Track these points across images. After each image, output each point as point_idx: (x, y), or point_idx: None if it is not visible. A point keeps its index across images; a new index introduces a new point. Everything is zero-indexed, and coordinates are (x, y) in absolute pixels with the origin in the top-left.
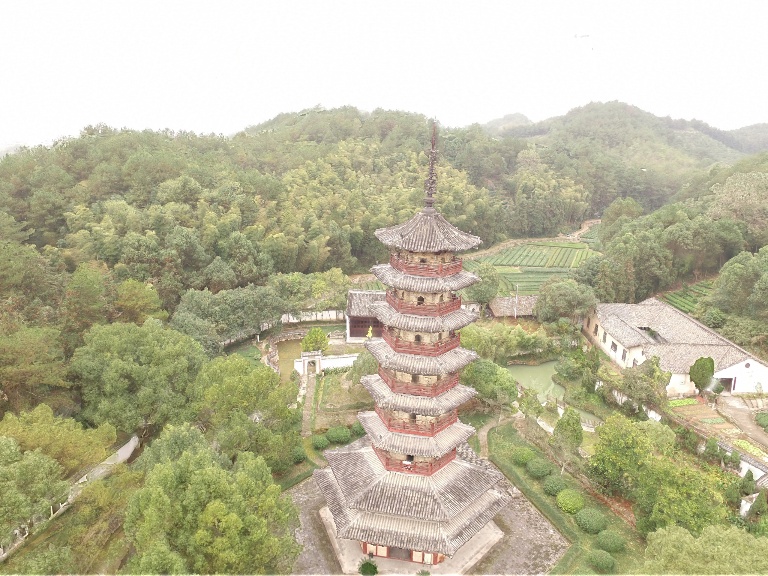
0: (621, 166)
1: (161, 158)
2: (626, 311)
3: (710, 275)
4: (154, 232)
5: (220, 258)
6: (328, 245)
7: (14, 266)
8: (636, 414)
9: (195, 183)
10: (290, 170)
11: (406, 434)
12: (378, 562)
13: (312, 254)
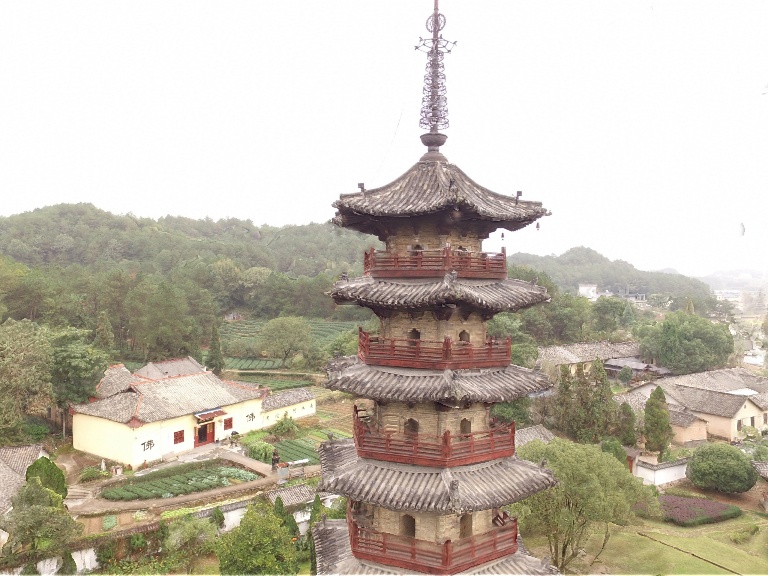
0: None
1: None
2: None
3: None
4: None
5: None
6: None
7: None
8: (62, 573)
9: None
10: None
11: None
12: None
13: None
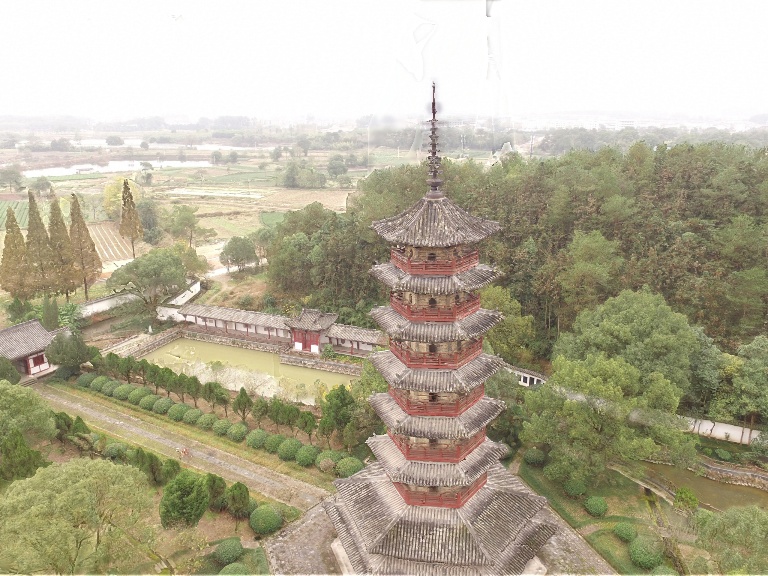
0: None
1: None
2: None
3: None
4: None
5: None
6: None
7: (733, 240)
8: None
9: None
10: None
11: None
12: None
13: None
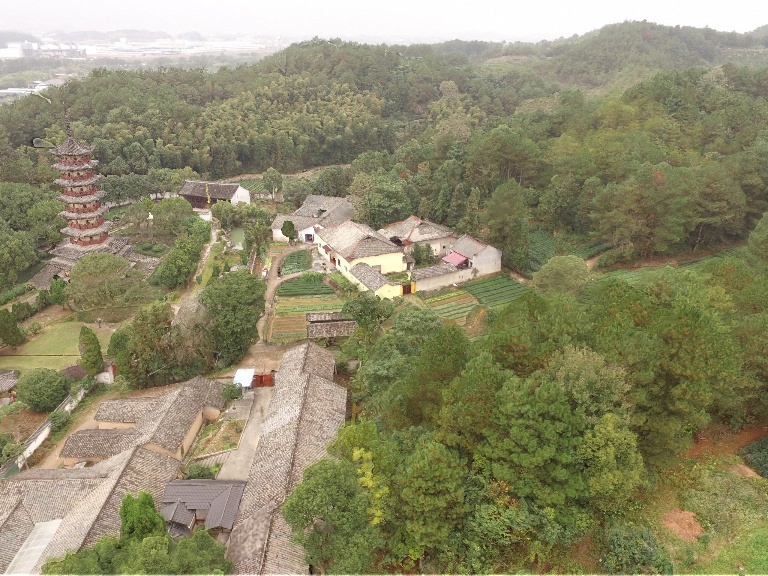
0: None
1: (119, 94)
2: (322, 200)
3: None
4: (84, 141)
5: None
6: (218, 153)
7: None
8: None
9: (129, 111)
10: (228, 99)
11: (74, 228)
12: (67, 278)
13: (194, 158)
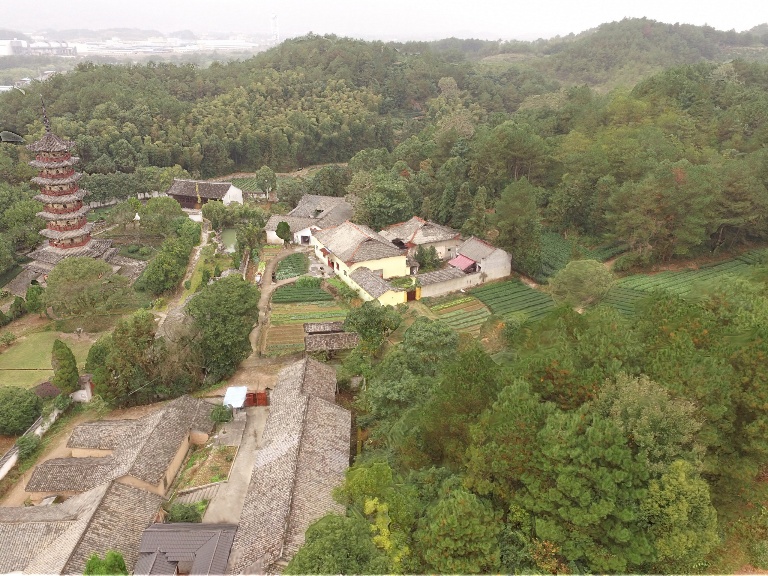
0: None
1: (105, 89)
2: (319, 200)
3: None
4: (68, 138)
5: (105, 155)
6: (209, 151)
7: None
8: None
9: (115, 107)
10: (220, 95)
11: (54, 230)
12: None
13: (184, 156)
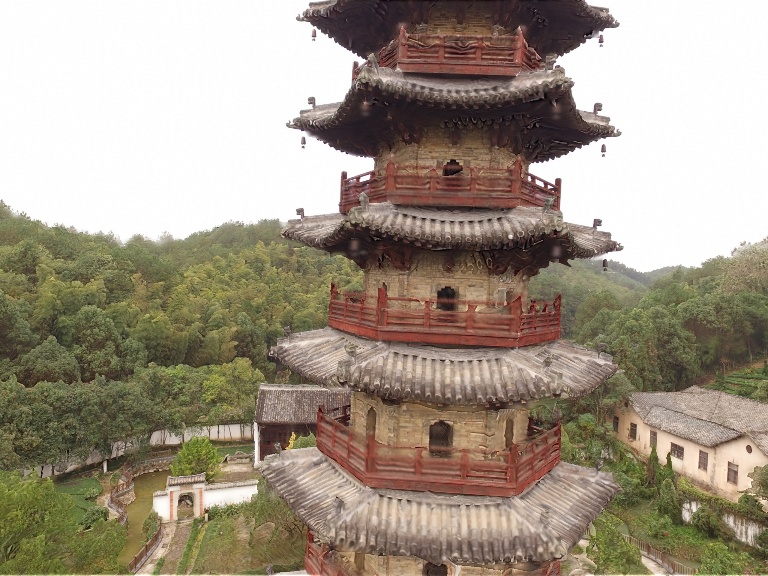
0: (566, 285)
1: (2, 224)
2: (671, 401)
3: (739, 365)
4: None
5: (54, 339)
6: None
7: None
8: None
9: (43, 250)
10: (192, 266)
11: None
12: None
13: (210, 349)
